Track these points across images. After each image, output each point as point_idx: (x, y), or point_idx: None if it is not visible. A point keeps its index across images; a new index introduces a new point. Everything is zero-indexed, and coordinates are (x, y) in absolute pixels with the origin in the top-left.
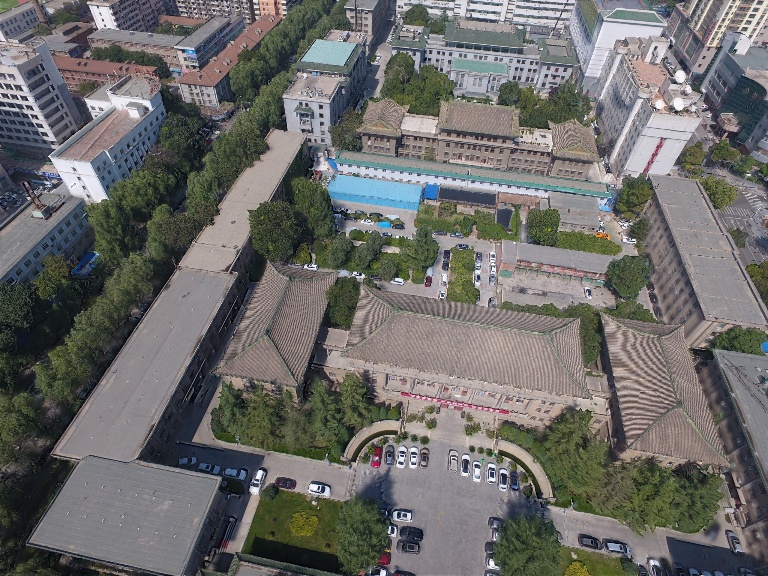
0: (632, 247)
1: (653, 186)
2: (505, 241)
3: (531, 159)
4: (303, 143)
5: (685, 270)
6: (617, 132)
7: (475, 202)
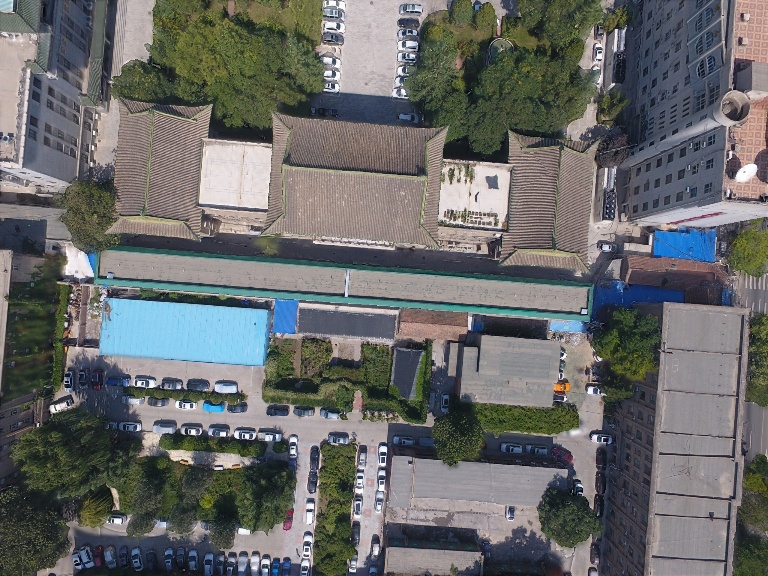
0: (598, 400)
1: (661, 344)
2: (397, 460)
3: (463, 235)
4: (12, 277)
5: (644, 552)
6: (652, 110)
7: (360, 335)
